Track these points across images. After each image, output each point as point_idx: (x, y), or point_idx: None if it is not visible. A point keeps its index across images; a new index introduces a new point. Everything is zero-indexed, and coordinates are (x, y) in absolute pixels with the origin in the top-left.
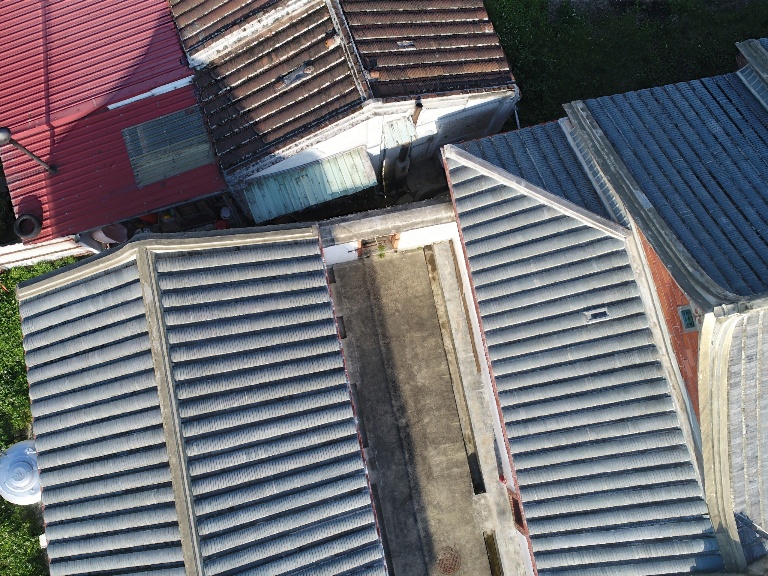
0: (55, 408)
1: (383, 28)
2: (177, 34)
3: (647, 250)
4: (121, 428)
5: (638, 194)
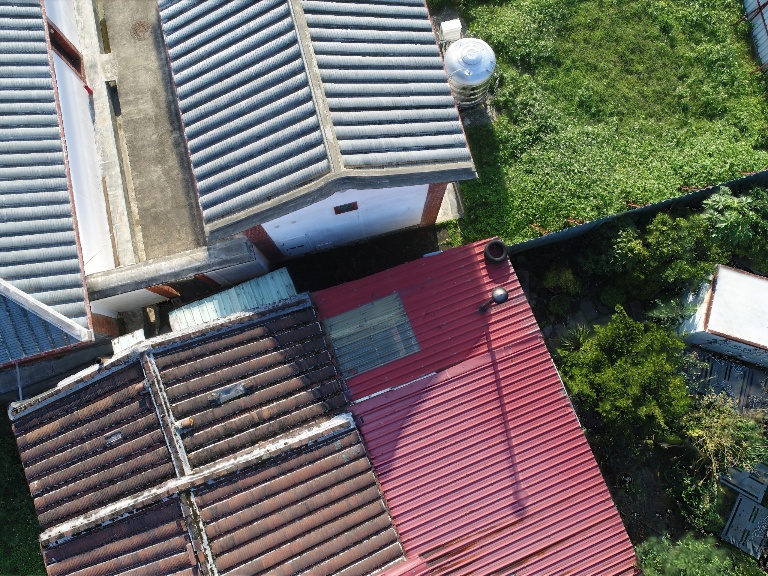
0: (422, 71)
1: (135, 452)
2: (368, 451)
3: None
4: (355, 45)
5: None
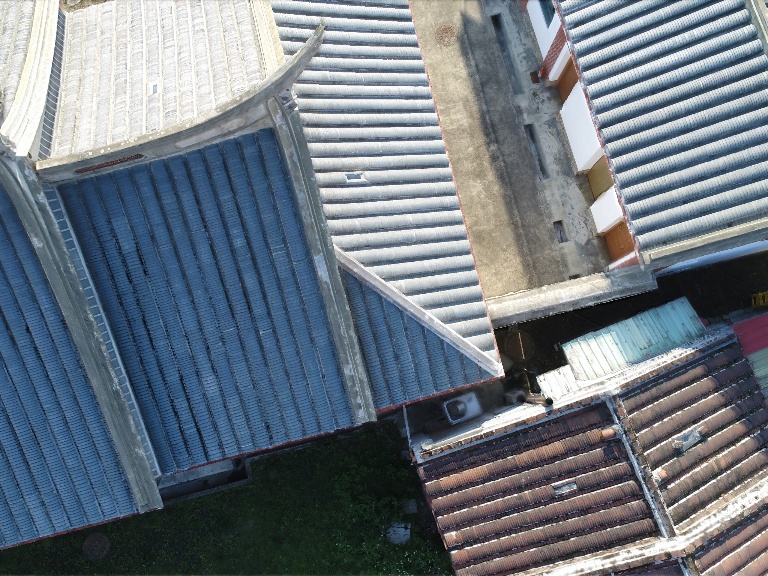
0: None
1: (597, 505)
2: None
3: None
4: None
5: (326, 276)
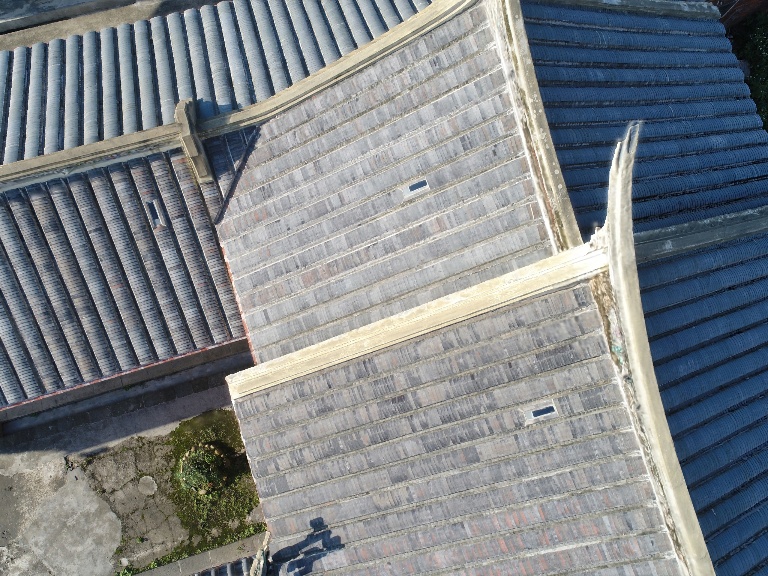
0: None
1: None
2: None
3: None
4: None
5: None
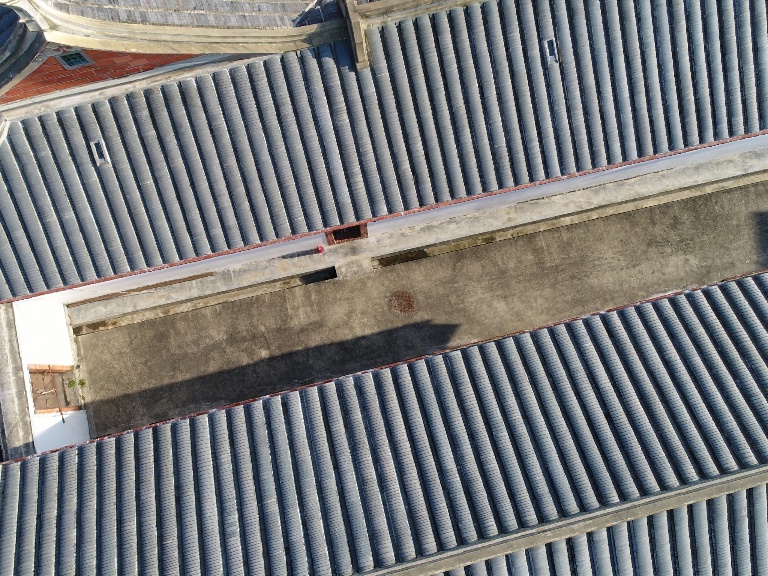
0: None
1: None
2: None
3: (11, 98)
4: None
5: None
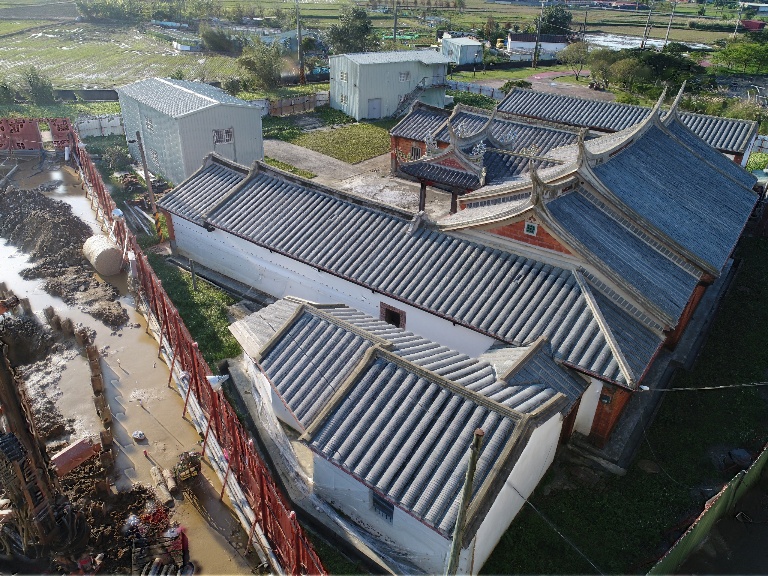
0: None
1: None
2: None
3: None
4: None
5: None
